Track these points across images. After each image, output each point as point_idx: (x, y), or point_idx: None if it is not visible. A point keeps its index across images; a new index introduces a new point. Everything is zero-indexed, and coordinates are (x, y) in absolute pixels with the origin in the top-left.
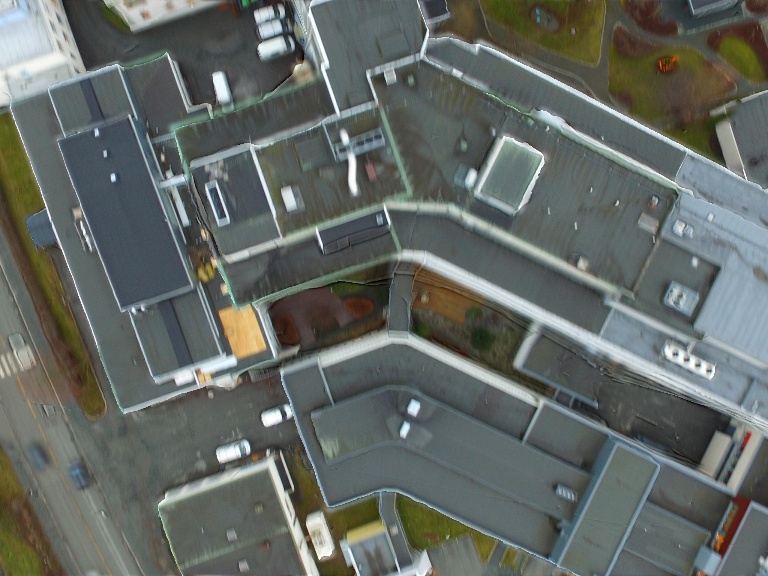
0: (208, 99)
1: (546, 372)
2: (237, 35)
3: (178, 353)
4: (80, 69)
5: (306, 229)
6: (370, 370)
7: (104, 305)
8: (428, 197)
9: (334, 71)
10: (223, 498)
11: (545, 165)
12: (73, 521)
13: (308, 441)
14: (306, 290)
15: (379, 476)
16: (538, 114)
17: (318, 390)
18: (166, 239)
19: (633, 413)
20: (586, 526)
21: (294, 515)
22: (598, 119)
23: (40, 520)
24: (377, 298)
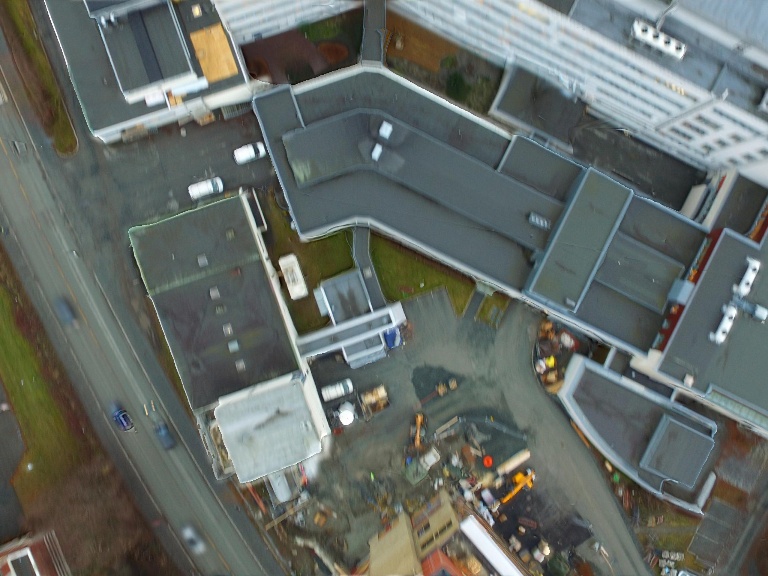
0: None
1: (521, 114)
2: None
3: (148, 69)
4: None
5: None
6: (342, 98)
7: (74, 24)
8: None
9: None
10: (194, 224)
11: None
12: (44, 260)
13: (280, 166)
14: (280, 34)
15: (351, 204)
16: None
17: (290, 115)
18: None
19: (609, 168)
20: (559, 250)
21: (267, 255)
22: None
23: (11, 258)
24: (351, 43)
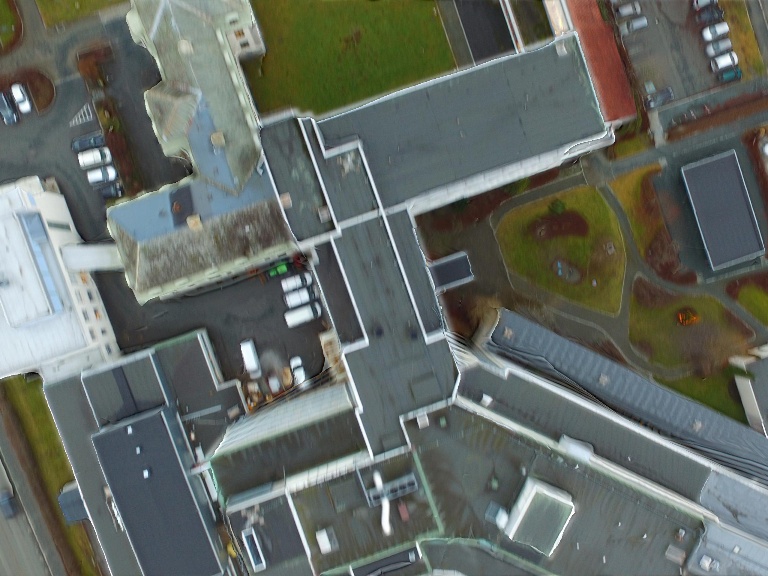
0: (236, 365)
1: None
2: (264, 301)
3: None
4: (111, 342)
5: (340, 567)
6: None
7: None
8: (460, 536)
9: (368, 415)
10: None
11: (574, 503)
12: None
13: None
14: None
15: None
16: (567, 449)
17: None
18: (197, 529)
19: None
20: None
21: None
22: (625, 440)
23: None
24: None
